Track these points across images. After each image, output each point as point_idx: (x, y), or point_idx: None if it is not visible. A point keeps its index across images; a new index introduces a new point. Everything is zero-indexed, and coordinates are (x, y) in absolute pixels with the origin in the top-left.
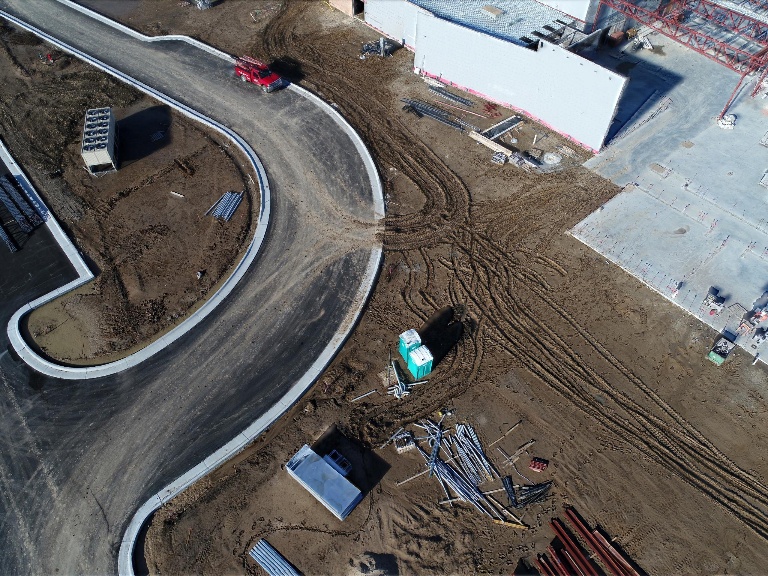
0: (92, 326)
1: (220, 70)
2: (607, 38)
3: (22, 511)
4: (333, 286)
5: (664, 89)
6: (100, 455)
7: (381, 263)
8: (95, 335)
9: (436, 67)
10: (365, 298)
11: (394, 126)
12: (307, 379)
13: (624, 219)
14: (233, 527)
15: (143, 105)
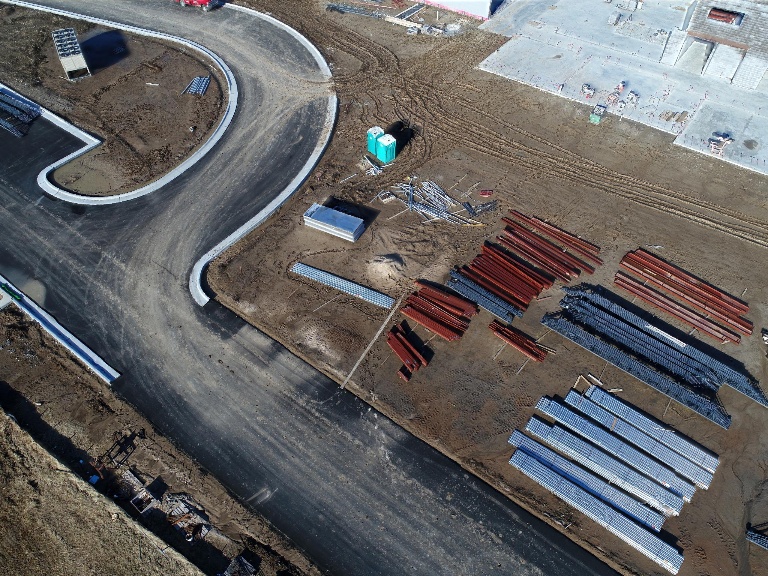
0: (112, 172)
1: (159, 1)
2: None
3: (100, 281)
4: (304, 122)
5: None
6: (151, 241)
7: (338, 104)
8: (117, 176)
9: None
10: (332, 124)
11: (322, 22)
12: (302, 175)
13: (515, 55)
14: (273, 260)
15: (97, 32)
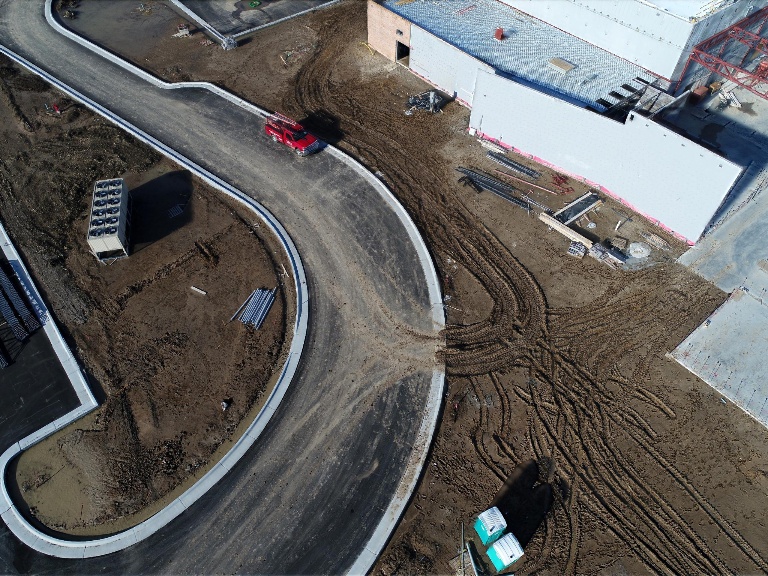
0: (94, 477)
1: (247, 126)
2: (689, 94)
3: None
4: (387, 426)
5: (761, 160)
6: None
7: (444, 393)
8: (97, 491)
9: (496, 129)
10: (428, 445)
11: (449, 203)
12: (360, 567)
13: (737, 338)
14: None
15: (160, 170)
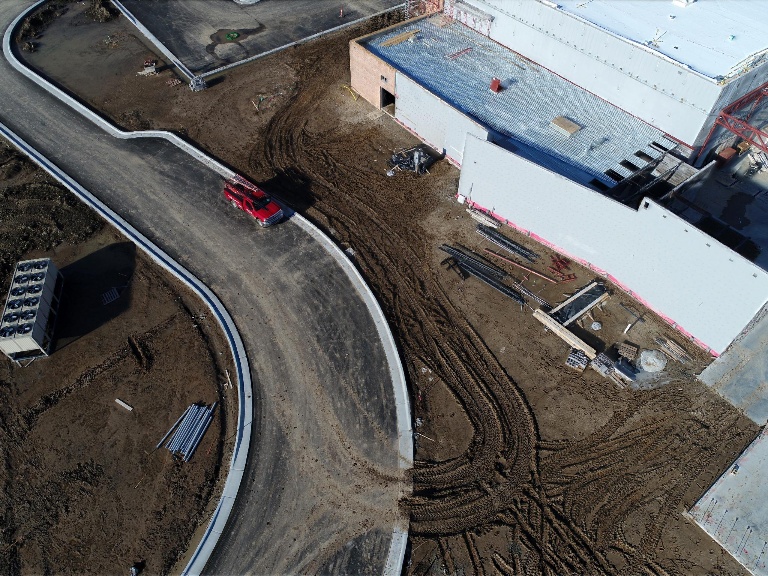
0: None
1: (206, 187)
2: (713, 156)
3: None
4: None
5: None
6: None
7: (406, 561)
8: None
9: (487, 199)
10: None
11: (429, 291)
12: None
13: None
14: None
15: (101, 241)
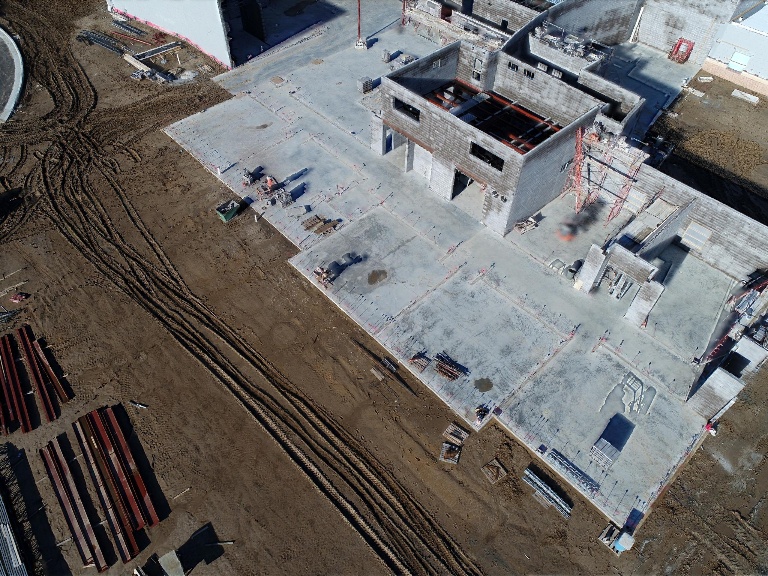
0: None
1: None
2: None
3: None
4: None
5: (328, 20)
6: None
7: None
8: None
9: (120, 3)
10: None
11: (62, 52)
12: None
13: (218, 118)
14: None
15: None
